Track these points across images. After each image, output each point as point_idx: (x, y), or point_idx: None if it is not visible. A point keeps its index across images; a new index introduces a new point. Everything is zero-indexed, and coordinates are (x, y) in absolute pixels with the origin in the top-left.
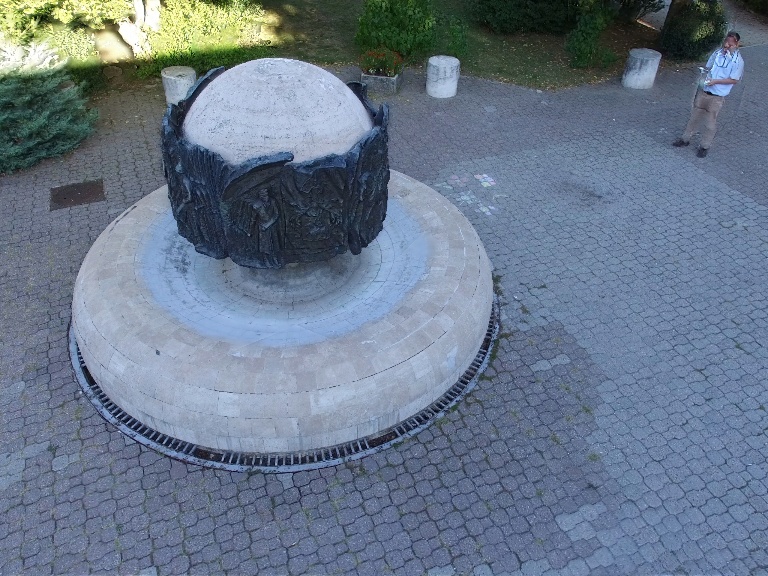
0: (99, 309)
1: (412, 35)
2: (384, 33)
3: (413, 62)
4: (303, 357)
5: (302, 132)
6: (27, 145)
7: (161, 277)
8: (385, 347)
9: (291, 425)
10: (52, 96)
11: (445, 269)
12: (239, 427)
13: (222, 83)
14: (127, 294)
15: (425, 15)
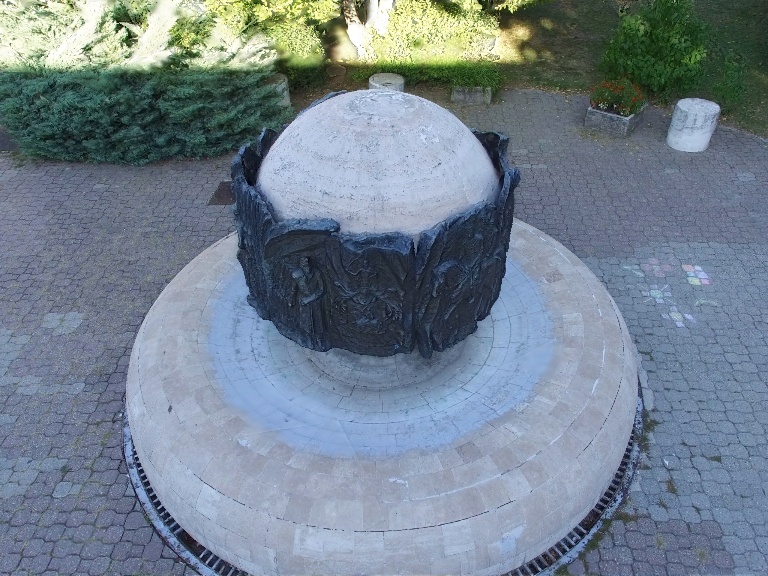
0: (151, 336)
1: (670, 68)
2: (634, 62)
3: (665, 100)
4: (311, 474)
5: (371, 194)
6: (216, 135)
7: (232, 314)
8: (416, 497)
9: (267, 556)
10: (252, 90)
11: (554, 404)
12: (214, 532)
13: (309, 114)
14: (184, 326)
15: (693, 45)
